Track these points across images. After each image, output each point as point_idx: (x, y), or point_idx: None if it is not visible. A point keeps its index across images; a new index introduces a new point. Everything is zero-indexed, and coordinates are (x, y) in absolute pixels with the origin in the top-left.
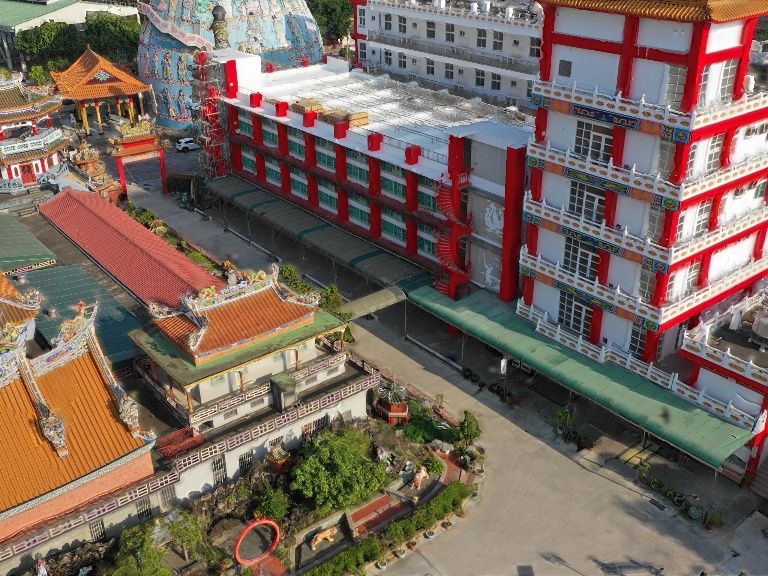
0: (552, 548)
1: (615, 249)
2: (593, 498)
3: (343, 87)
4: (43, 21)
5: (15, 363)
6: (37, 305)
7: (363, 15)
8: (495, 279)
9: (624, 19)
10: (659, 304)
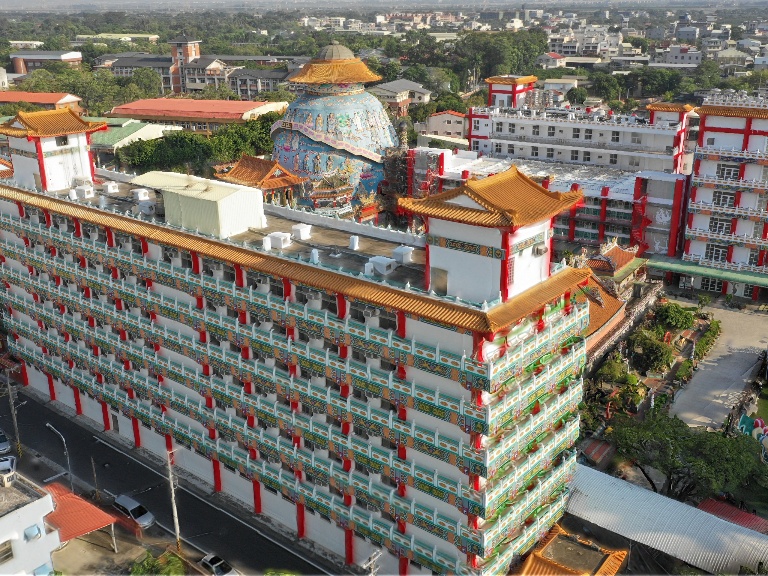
0: (765, 335)
1: (745, 217)
2: (763, 321)
3: (496, 166)
4: (130, 140)
5: None
6: None
7: (477, 124)
8: (662, 247)
9: (746, 120)
10: (766, 238)
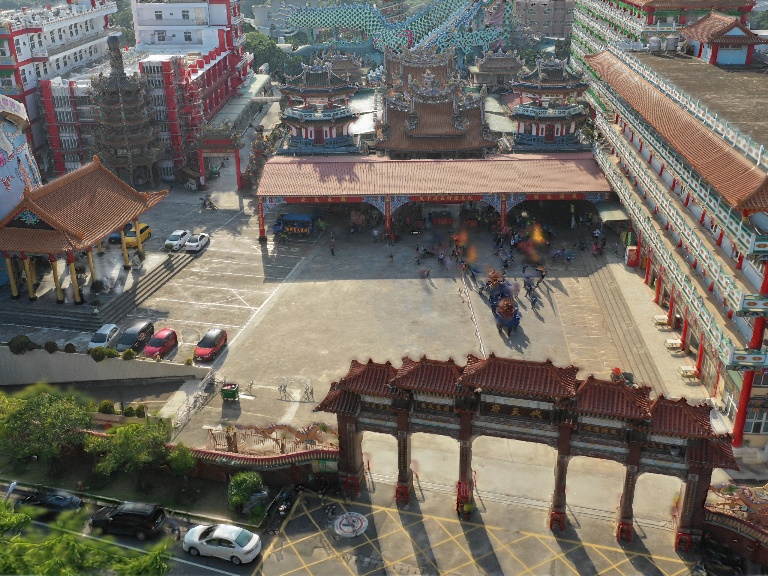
0: None
1: None
2: None
3: None
4: None
5: None
6: None
7: None
8: None
9: None
10: None
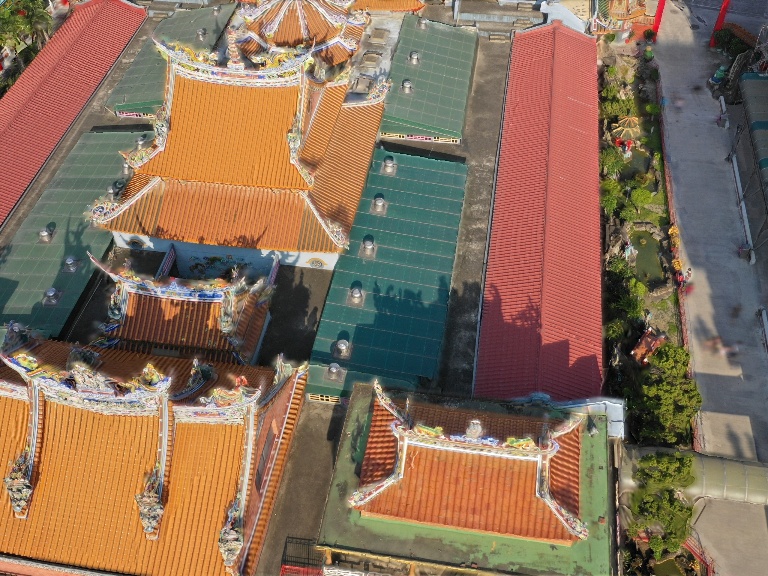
0: None
1: None
2: None
3: None
4: None
5: (155, 402)
6: (341, 243)
7: None
8: None
9: None
10: None
